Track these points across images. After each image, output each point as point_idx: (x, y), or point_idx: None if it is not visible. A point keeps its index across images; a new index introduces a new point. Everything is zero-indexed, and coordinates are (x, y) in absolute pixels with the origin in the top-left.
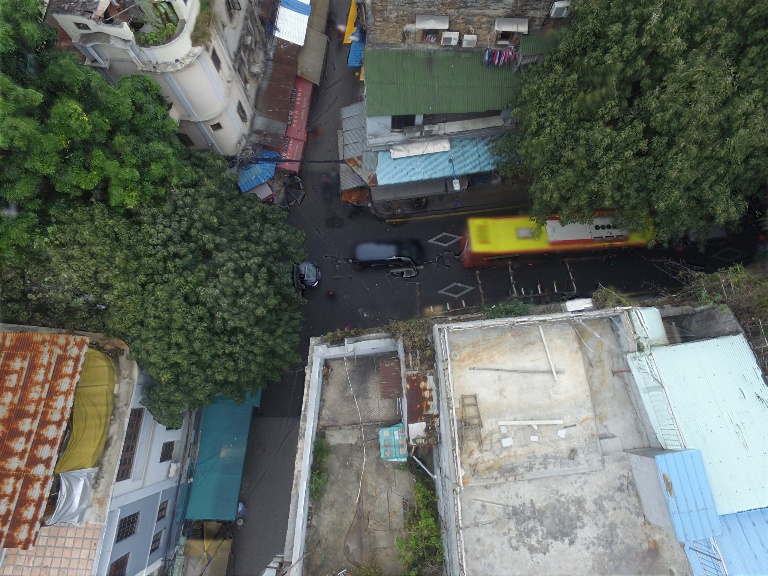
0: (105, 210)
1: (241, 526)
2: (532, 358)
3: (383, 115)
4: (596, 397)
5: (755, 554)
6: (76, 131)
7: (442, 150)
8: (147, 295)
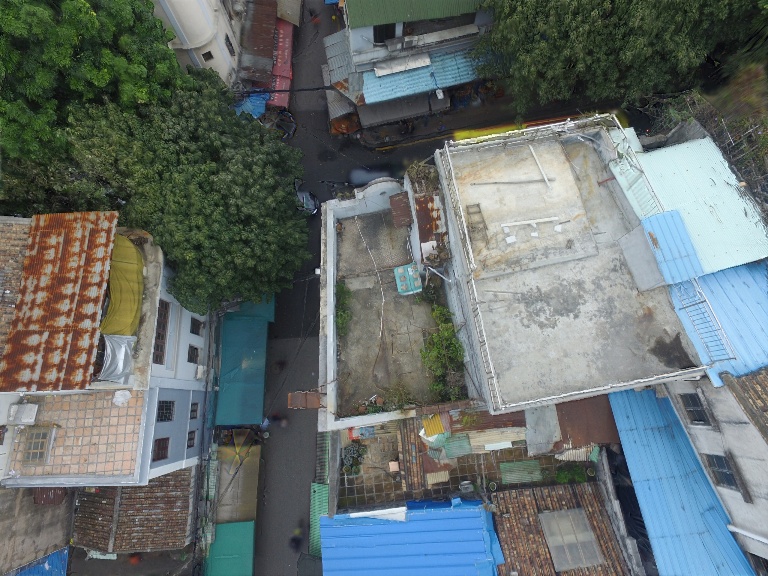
0: (117, 109)
1: (267, 440)
2: (525, 171)
3: (365, 26)
4: (586, 204)
5: (736, 307)
6: (86, 25)
7: (423, 65)
8: (165, 183)
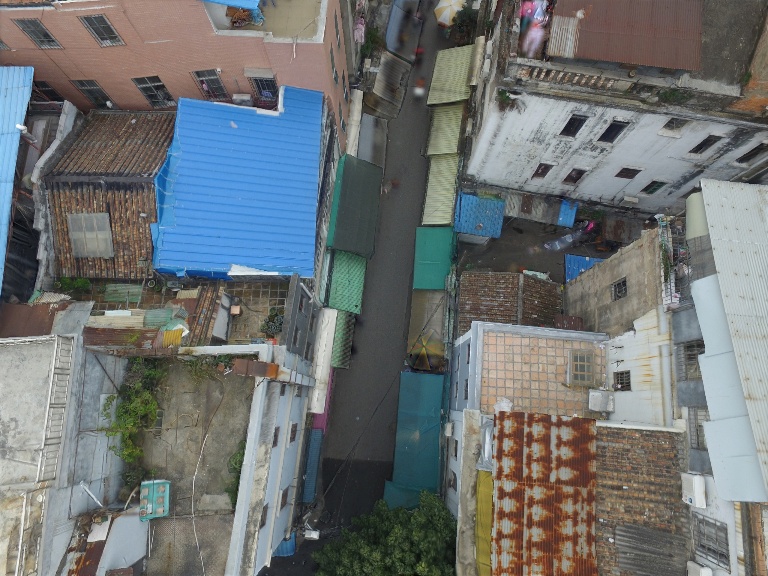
0: None
1: None
2: None
3: None
4: None
5: None
6: None
7: None
8: None
